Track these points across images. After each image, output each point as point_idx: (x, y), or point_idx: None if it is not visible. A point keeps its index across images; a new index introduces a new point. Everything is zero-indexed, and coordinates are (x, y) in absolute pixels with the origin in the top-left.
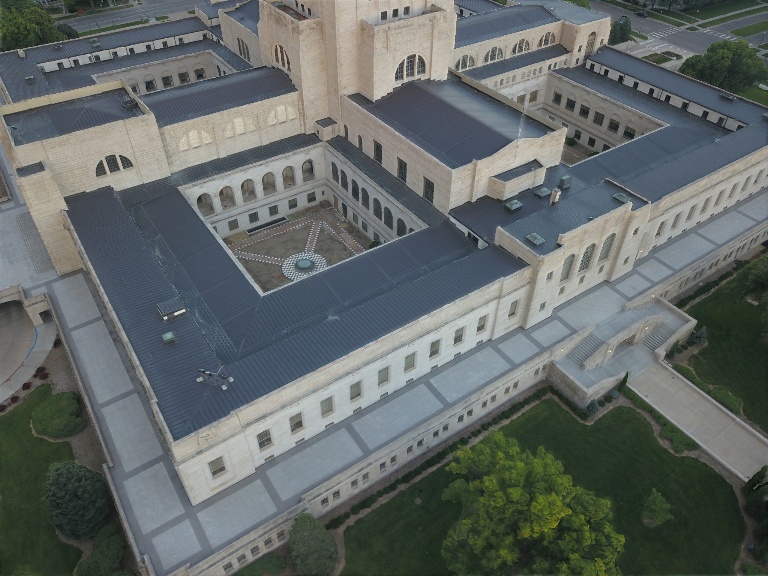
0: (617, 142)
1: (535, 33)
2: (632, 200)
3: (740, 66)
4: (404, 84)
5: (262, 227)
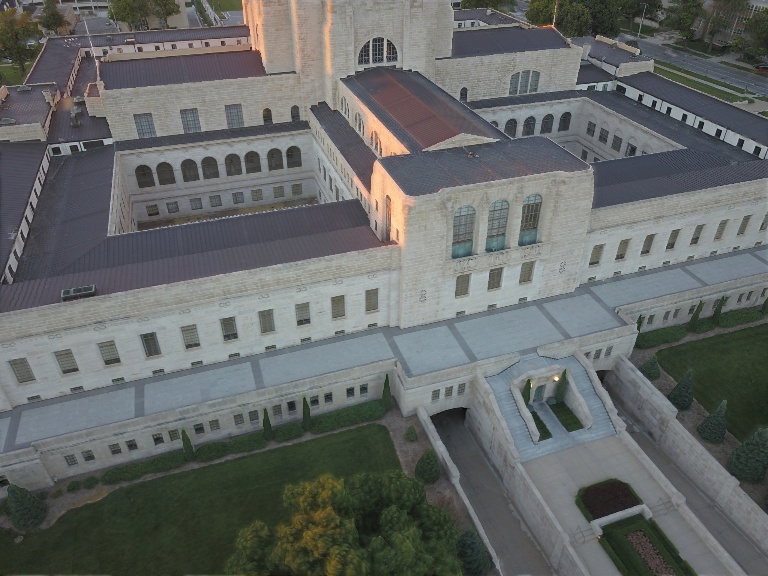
0: None
1: None
2: None
3: None
4: None
5: None
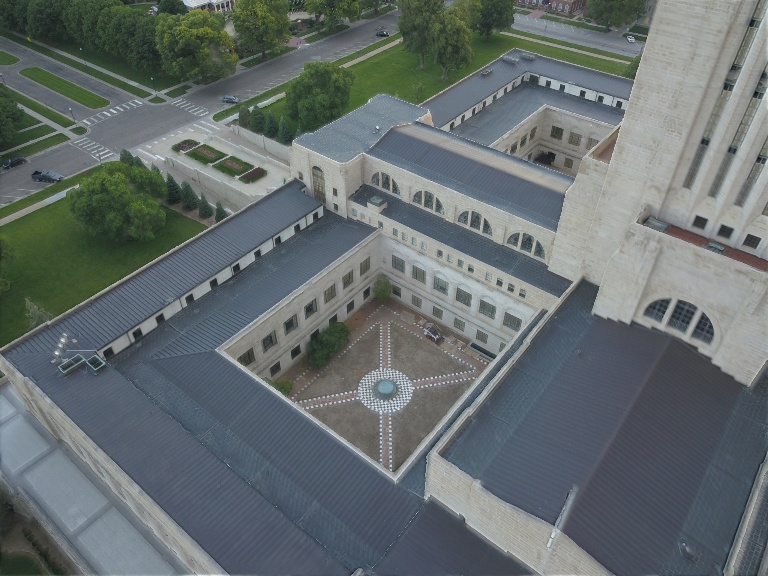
0: None
1: None
2: None
3: (350, 77)
4: None
5: None
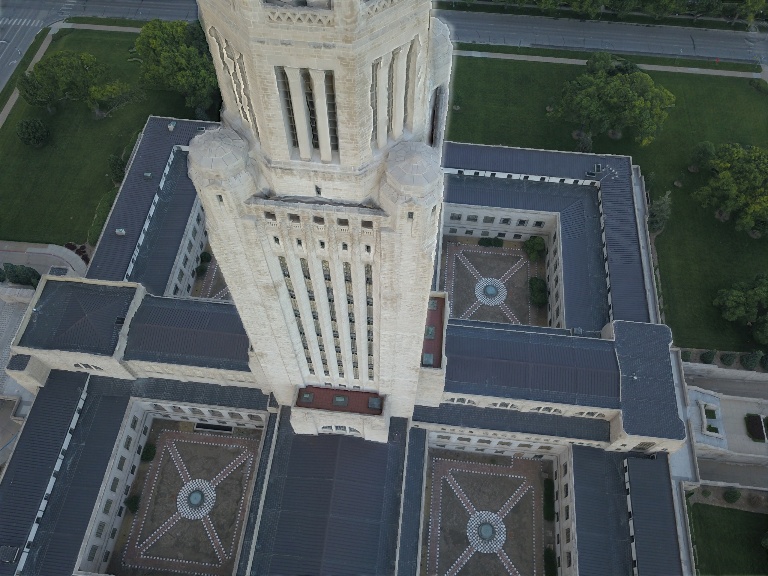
0: (563, 573)
1: (571, 408)
2: None
3: None
4: (332, 433)
5: (209, 428)
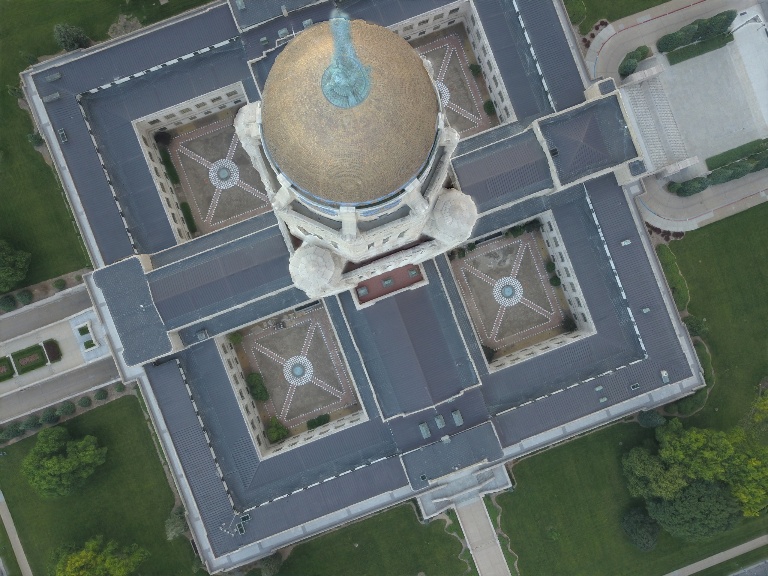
0: None
1: None
2: (234, 3)
3: None
4: None
5: None
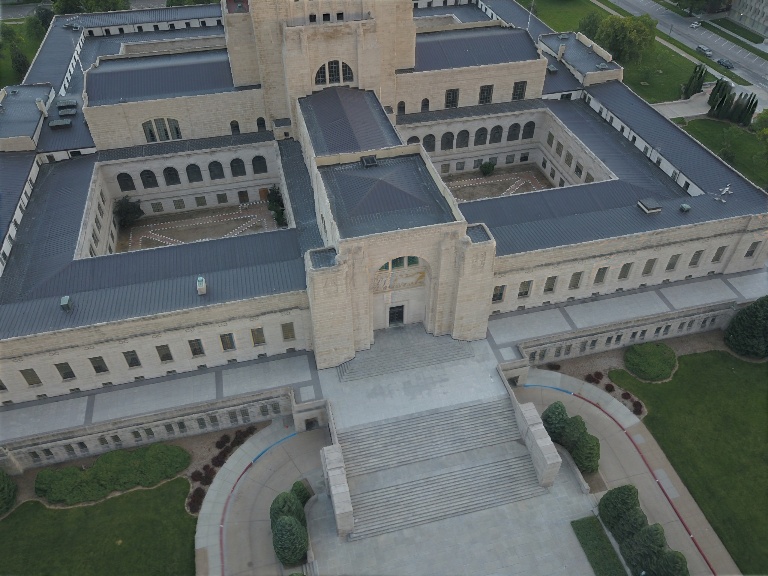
0: None
1: None
2: None
3: None
4: None
5: None
